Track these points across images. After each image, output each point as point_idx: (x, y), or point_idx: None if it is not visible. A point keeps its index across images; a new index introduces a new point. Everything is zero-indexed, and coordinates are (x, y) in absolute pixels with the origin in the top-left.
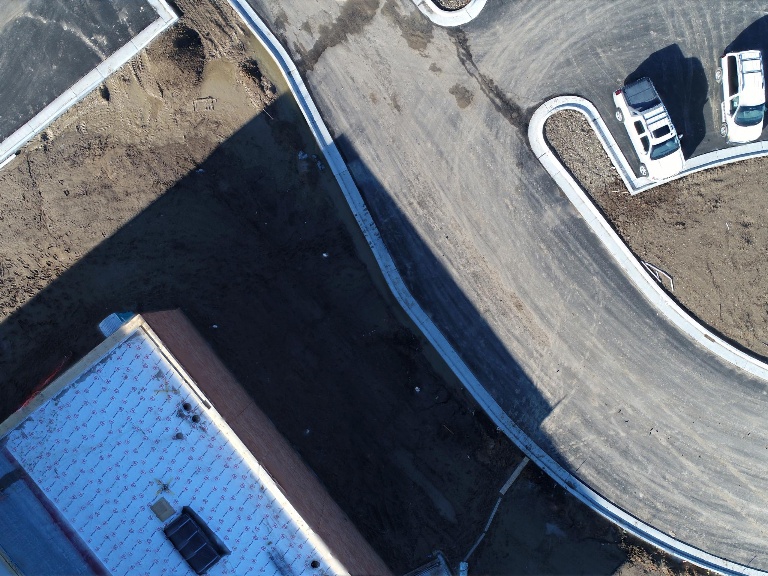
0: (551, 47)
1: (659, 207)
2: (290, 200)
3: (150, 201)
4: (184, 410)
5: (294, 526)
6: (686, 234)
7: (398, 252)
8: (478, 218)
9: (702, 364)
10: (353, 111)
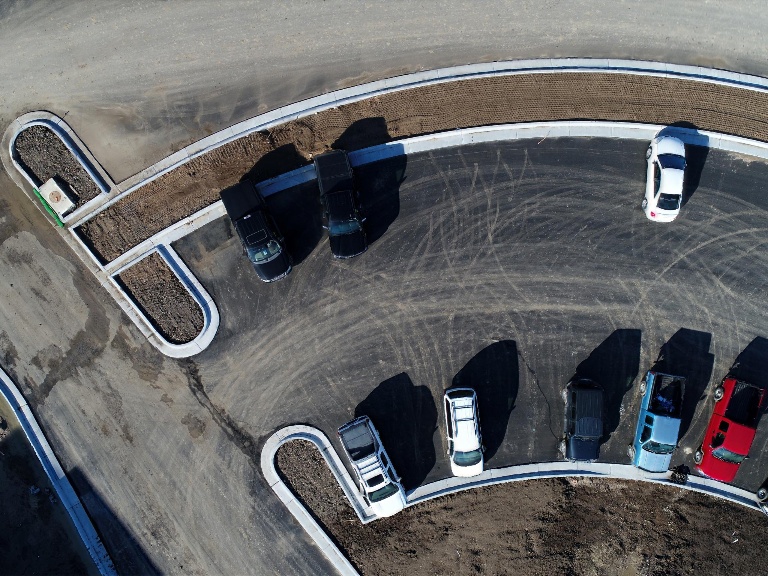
0: (281, 377)
1: (390, 535)
2: (23, 535)
3: None
4: None
5: None
6: (418, 561)
7: None
8: (212, 547)
9: None
10: (85, 444)
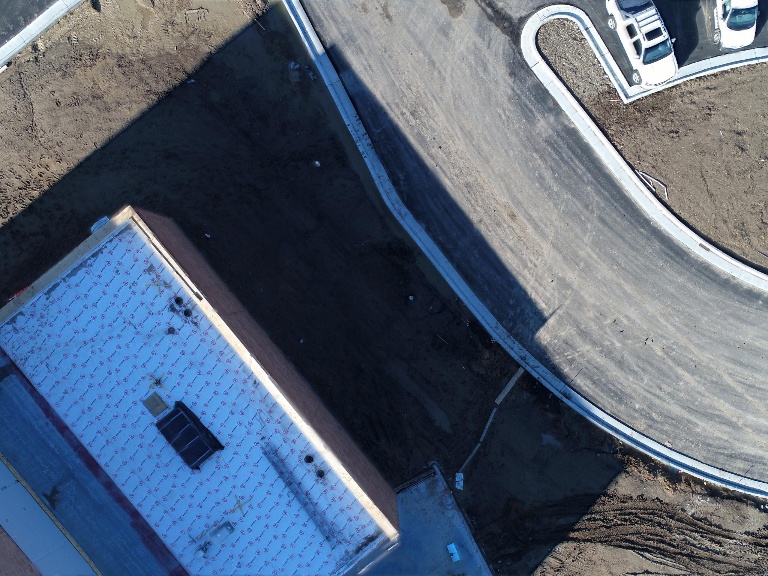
0: None
1: (652, 115)
2: (282, 110)
3: (142, 111)
4: (176, 304)
5: (287, 421)
6: (680, 142)
7: (391, 162)
8: (471, 128)
9: (697, 273)
10: (345, 21)
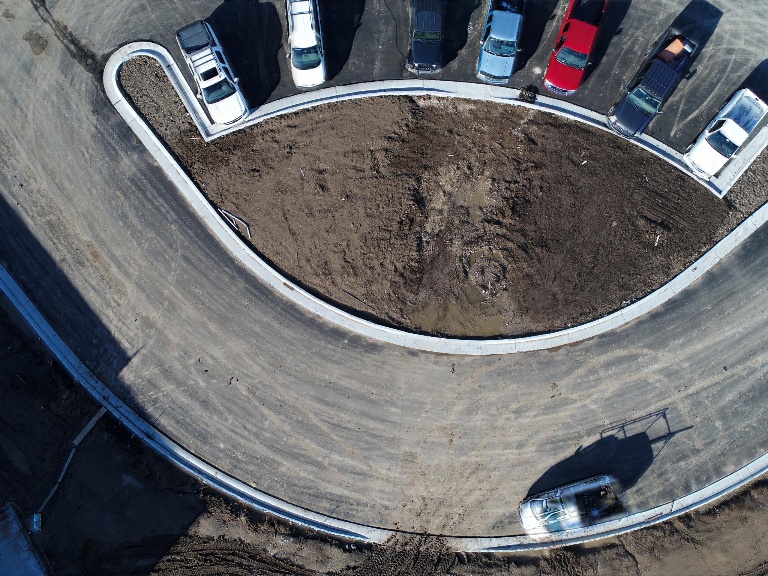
0: None
1: (233, 153)
2: None
3: None
4: None
5: None
6: (261, 181)
7: None
8: (53, 166)
9: (282, 312)
10: None
